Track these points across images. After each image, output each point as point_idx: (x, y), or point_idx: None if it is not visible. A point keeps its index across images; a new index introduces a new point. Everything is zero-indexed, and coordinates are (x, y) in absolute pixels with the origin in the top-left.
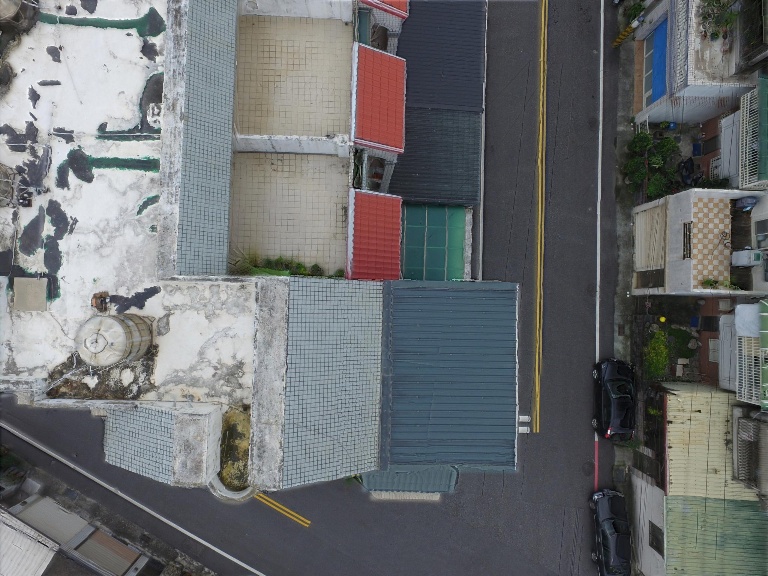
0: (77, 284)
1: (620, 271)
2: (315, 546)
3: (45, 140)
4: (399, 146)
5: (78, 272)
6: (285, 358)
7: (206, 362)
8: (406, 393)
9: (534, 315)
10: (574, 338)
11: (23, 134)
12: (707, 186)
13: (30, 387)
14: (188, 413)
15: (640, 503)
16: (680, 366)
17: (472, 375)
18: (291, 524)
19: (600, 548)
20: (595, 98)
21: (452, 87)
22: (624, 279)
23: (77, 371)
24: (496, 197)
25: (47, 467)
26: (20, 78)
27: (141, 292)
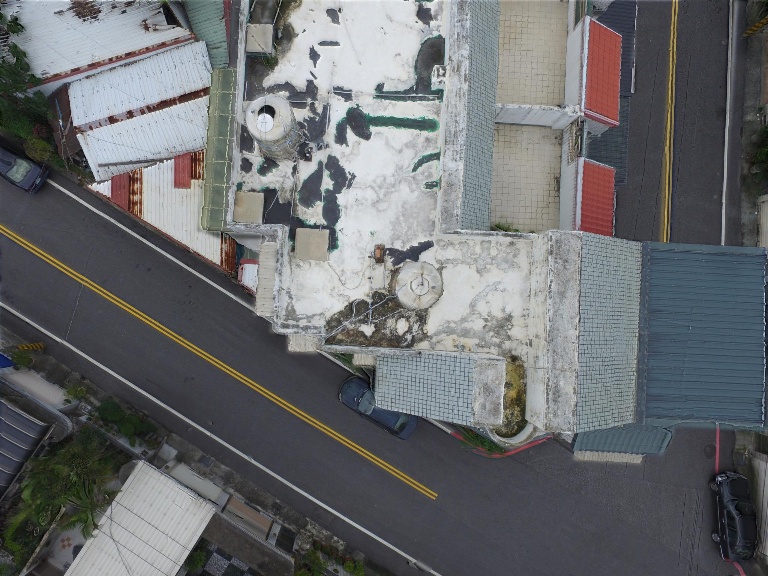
0: (354, 236)
1: None
2: (441, 519)
3: (324, 98)
4: (616, 119)
5: (355, 225)
6: (578, 308)
7: (477, 314)
8: (662, 350)
9: None
10: None
11: (303, 92)
12: None
13: (318, 332)
14: (487, 358)
15: (763, 486)
16: None
17: (723, 335)
18: (419, 496)
19: (724, 528)
20: (722, 88)
21: None
22: None
23: (354, 319)
24: None
25: (184, 434)
26: (301, 38)
27: (415, 246)
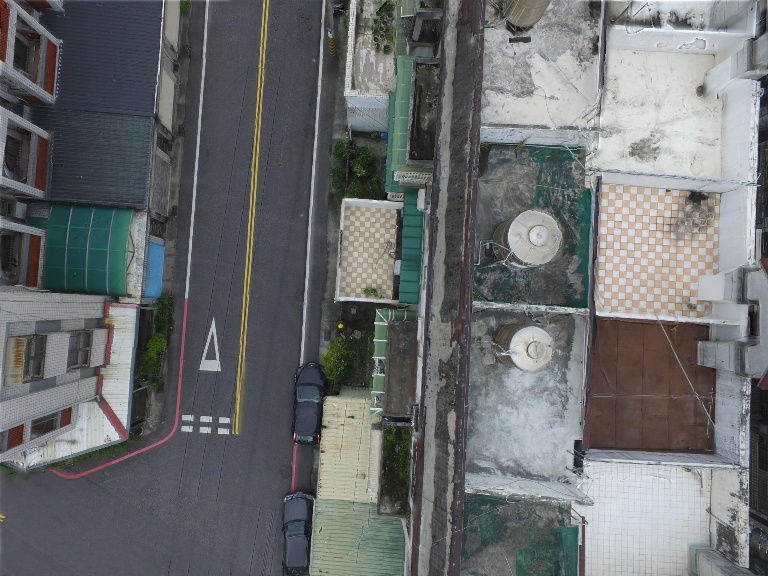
0: None
1: (328, 277)
2: (9, 541)
3: None
4: None
5: None
6: None
7: None
8: None
9: (240, 318)
10: (279, 342)
11: None
12: None
13: None
14: None
15: None
16: None
17: None
18: None
19: None
20: (312, 106)
21: (123, 91)
22: (331, 285)
23: None
24: (209, 201)
25: None
26: None
27: None
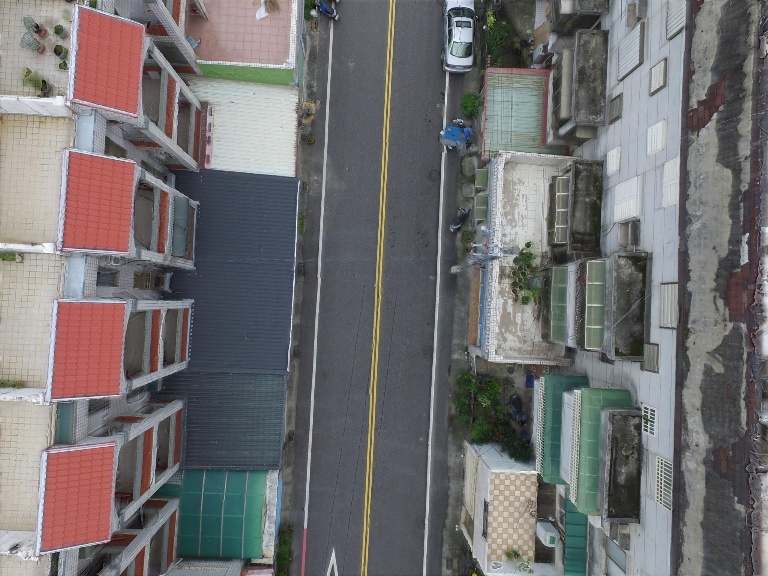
0: None
1: (449, 503)
2: None
3: None
4: (103, 538)
5: None
6: None
7: None
8: None
9: (360, 549)
10: (400, 572)
11: None
12: (516, 450)
13: None
14: None
15: None
16: None
17: None
18: None
19: None
20: (430, 325)
21: (256, 350)
22: (453, 512)
23: None
24: (326, 425)
25: None
26: None
27: None
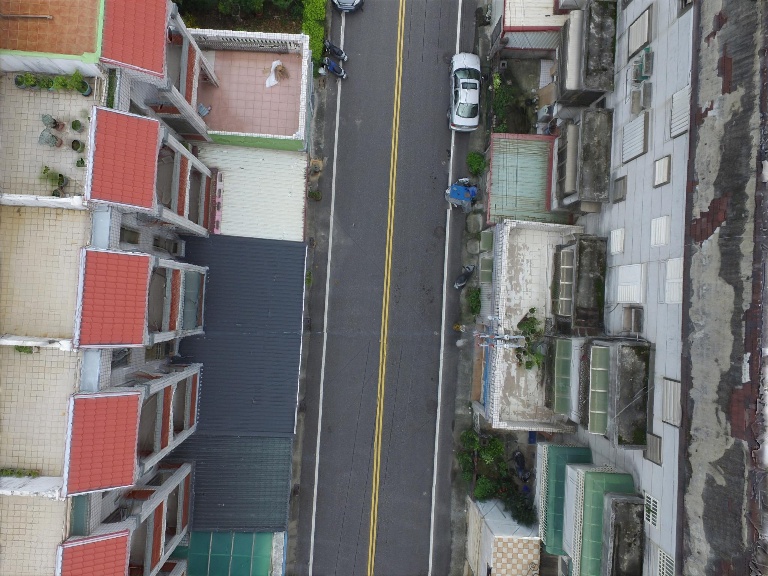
0: None
1: (452, 558)
2: None
3: None
4: None
5: None
6: None
7: None
8: None
9: None
10: None
11: None
12: (519, 513)
13: None
14: None
15: None
16: None
17: None
18: None
19: None
20: (434, 380)
21: (263, 413)
22: (456, 566)
23: None
24: (331, 480)
25: None
26: None
27: None
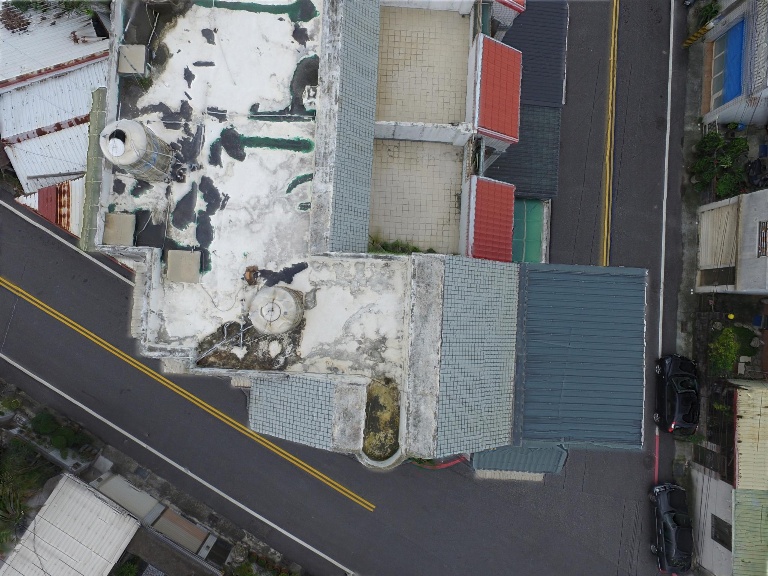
0: (228, 258)
1: (684, 269)
2: (379, 530)
3: (199, 119)
4: (515, 136)
5: (229, 246)
6: (440, 332)
7: (350, 336)
8: (539, 372)
9: None
10: None
11: (178, 112)
12: None
13: (186, 355)
14: (347, 382)
15: (701, 497)
16: (742, 364)
17: (602, 356)
18: (356, 508)
19: (661, 540)
20: (663, 98)
21: (533, 83)
22: (688, 277)
23: (227, 341)
24: (564, 193)
25: (120, 445)
26: (176, 59)
27: (289, 267)
